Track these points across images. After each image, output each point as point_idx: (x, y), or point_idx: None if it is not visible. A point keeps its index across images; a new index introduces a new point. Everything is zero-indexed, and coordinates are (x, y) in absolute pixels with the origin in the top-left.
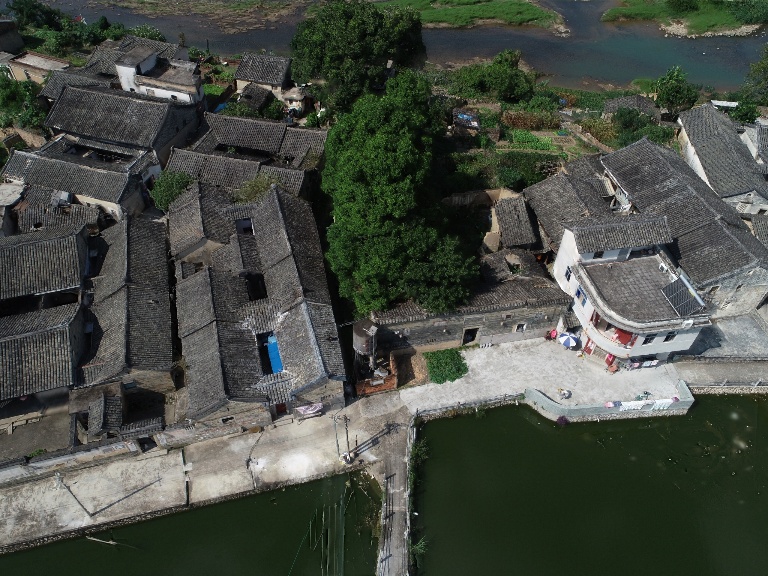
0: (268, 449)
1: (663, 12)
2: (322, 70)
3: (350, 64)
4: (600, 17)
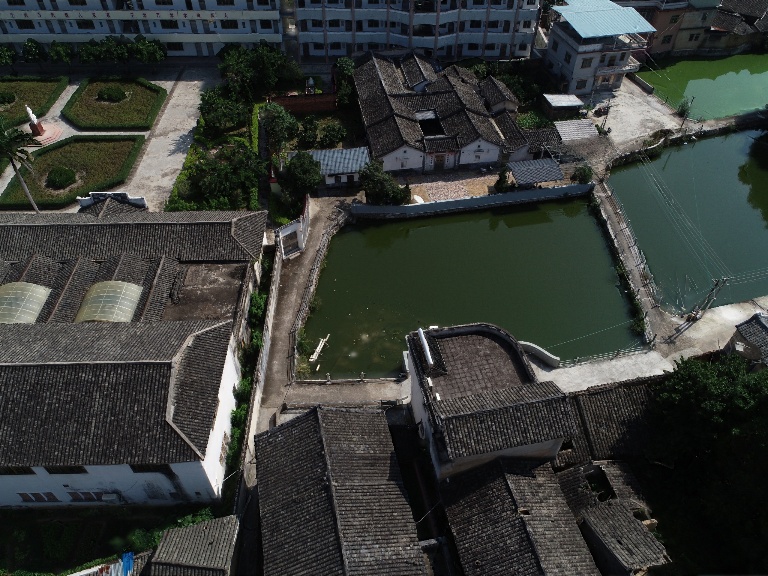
0: None
1: None
2: None
3: None
4: None
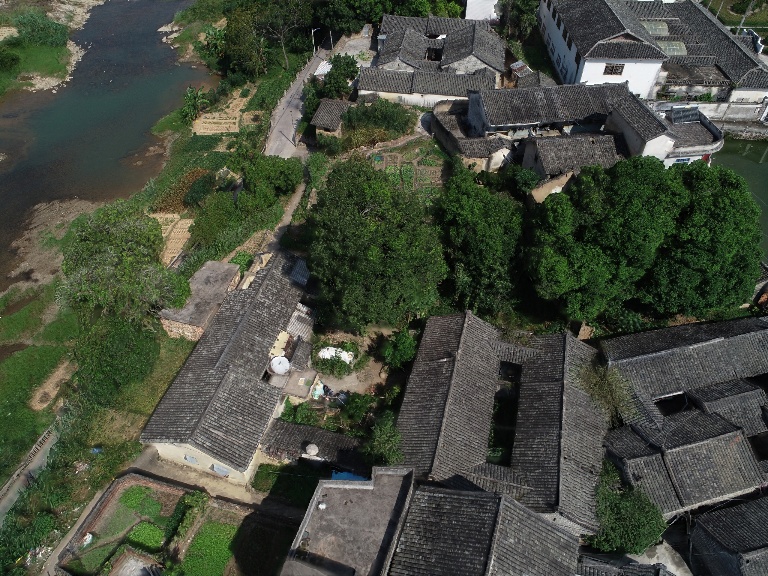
0: None
1: (1, 79)
2: (428, 264)
3: (429, 229)
4: None
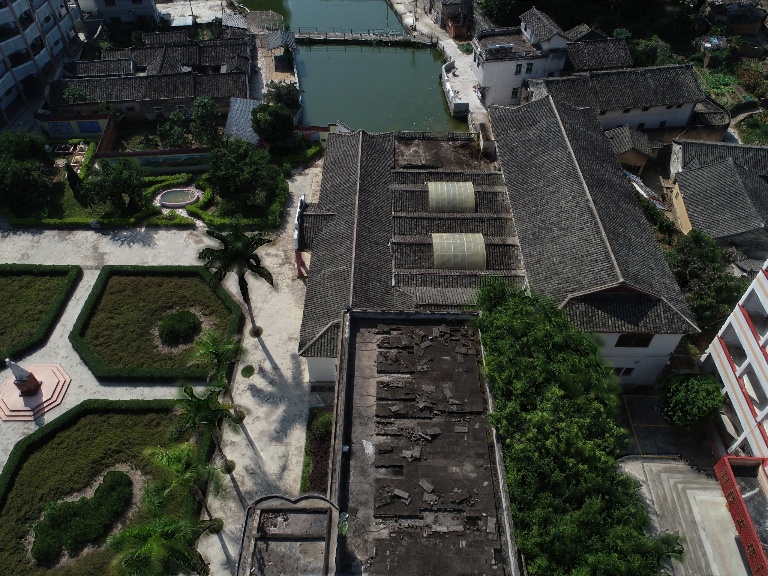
0: (417, 15)
1: None
2: None
3: None
4: None
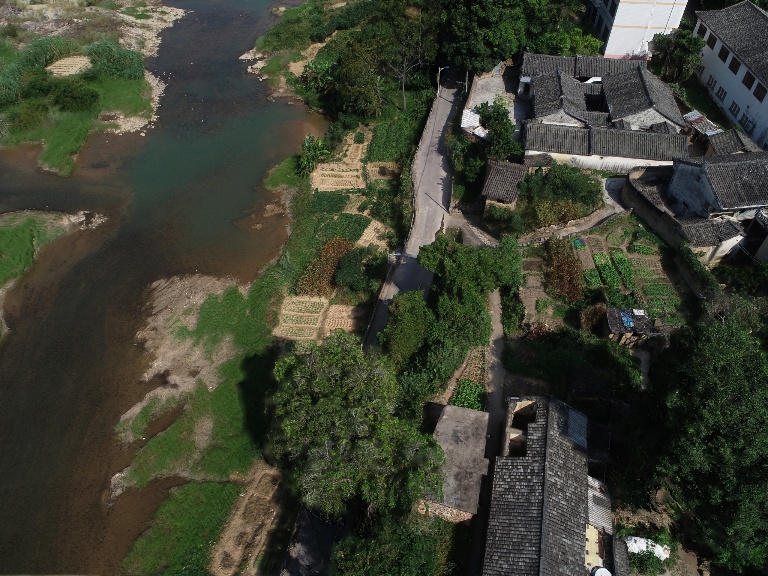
0: None
1: (82, 119)
2: None
3: None
4: (56, 174)
